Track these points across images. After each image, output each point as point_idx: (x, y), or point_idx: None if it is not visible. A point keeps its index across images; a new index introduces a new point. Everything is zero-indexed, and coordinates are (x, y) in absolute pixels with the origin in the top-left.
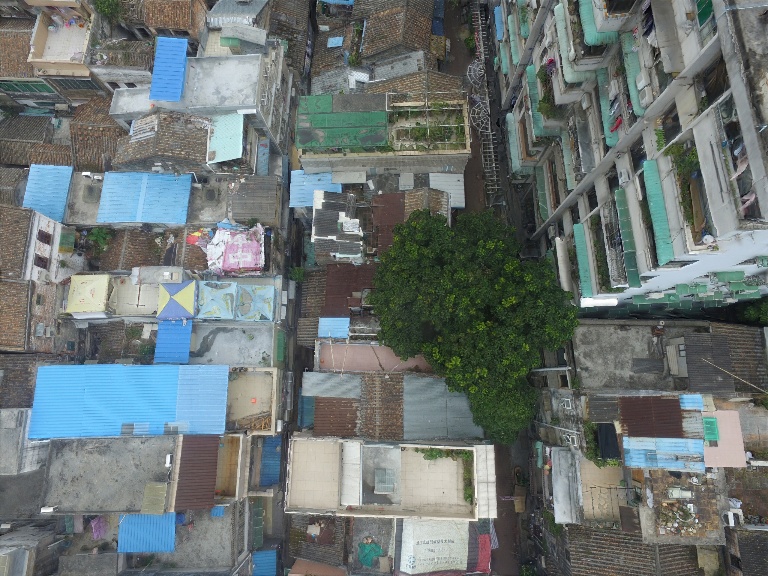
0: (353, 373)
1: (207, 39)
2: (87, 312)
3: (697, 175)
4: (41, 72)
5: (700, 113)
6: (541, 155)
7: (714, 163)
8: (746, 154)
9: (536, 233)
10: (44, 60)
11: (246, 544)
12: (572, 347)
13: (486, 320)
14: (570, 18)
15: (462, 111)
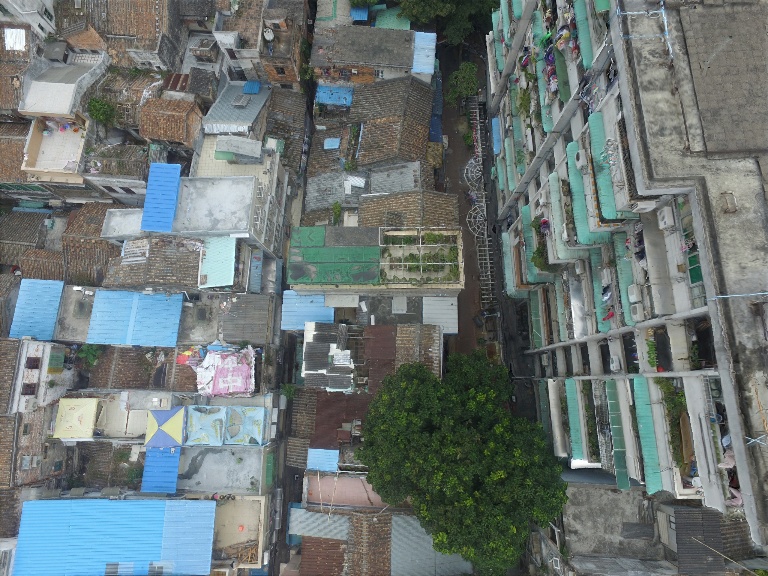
0: (341, 514)
1: (202, 144)
2: (75, 437)
3: (687, 414)
4: (35, 178)
5: (690, 362)
6: (535, 285)
7: (702, 440)
8: (734, 457)
9: (530, 352)
10: (37, 169)
11: None
12: (561, 512)
13: (474, 488)
14: (564, 198)
15: (456, 242)
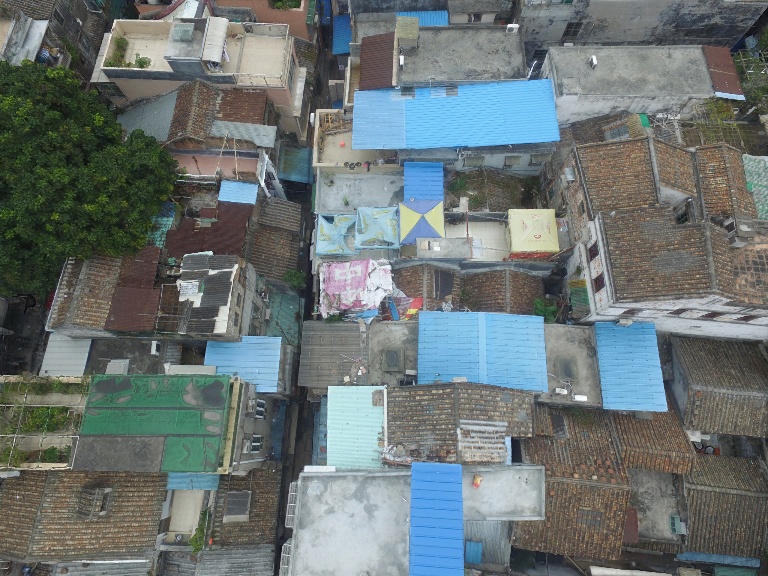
0: (215, 138)
1: None
2: None
3: None
4: None
5: None
6: None
7: None
8: None
9: None
10: None
11: None
12: None
13: None
14: None
15: None
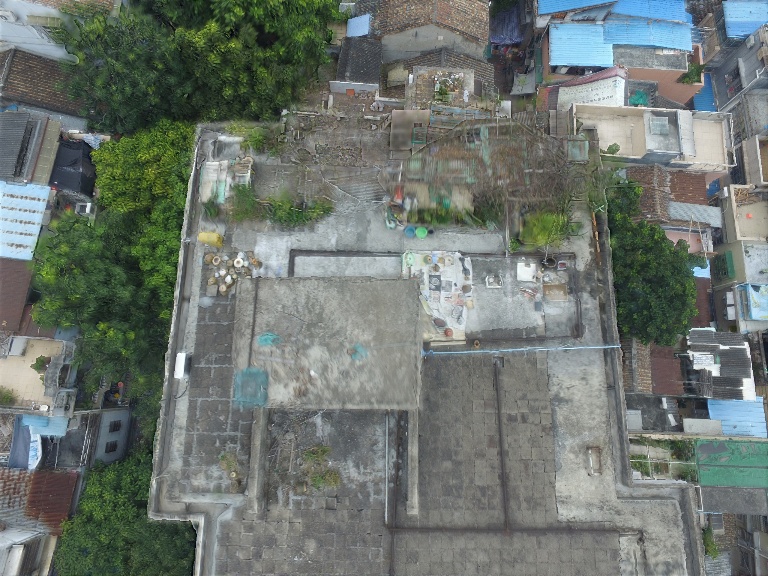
0: (681, 220)
1: None
2: None
3: None
4: None
5: None
6: None
7: None
8: None
9: None
10: None
11: None
12: None
13: None
14: None
15: None
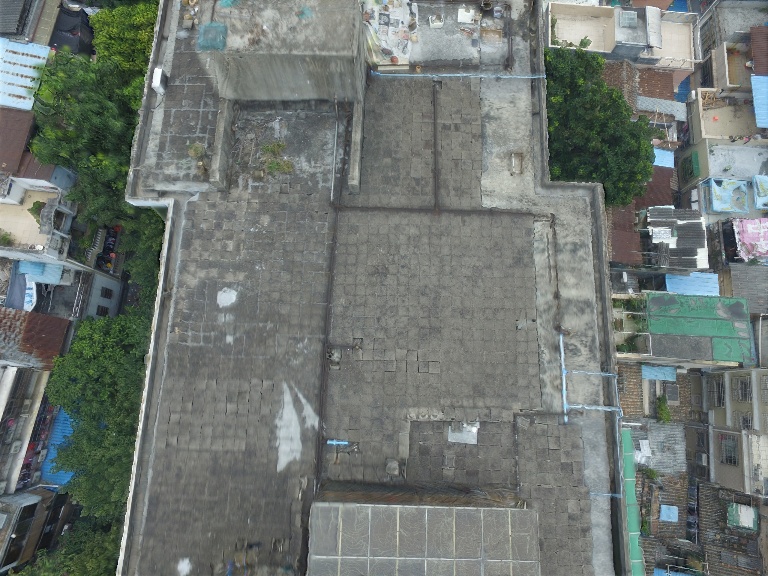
0: (647, 112)
1: None
2: None
3: None
4: None
5: None
6: None
7: None
8: None
9: None
10: None
11: (696, 36)
12: None
13: None
14: None
15: None
